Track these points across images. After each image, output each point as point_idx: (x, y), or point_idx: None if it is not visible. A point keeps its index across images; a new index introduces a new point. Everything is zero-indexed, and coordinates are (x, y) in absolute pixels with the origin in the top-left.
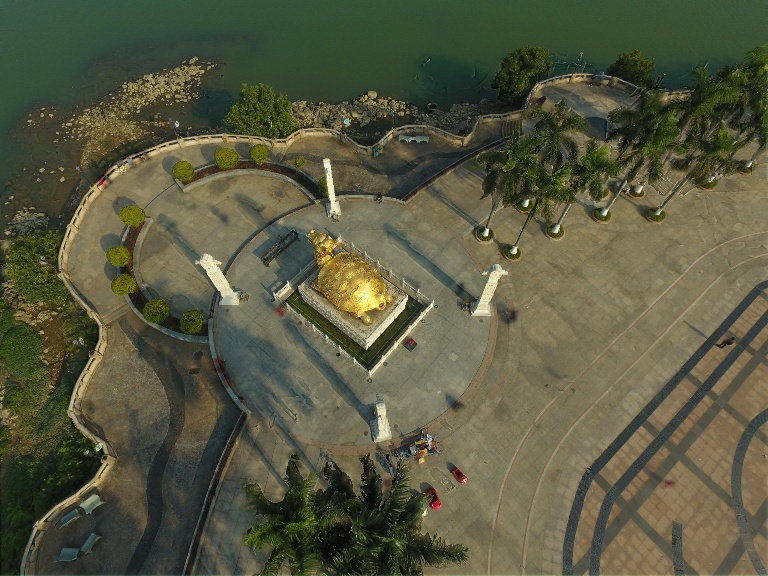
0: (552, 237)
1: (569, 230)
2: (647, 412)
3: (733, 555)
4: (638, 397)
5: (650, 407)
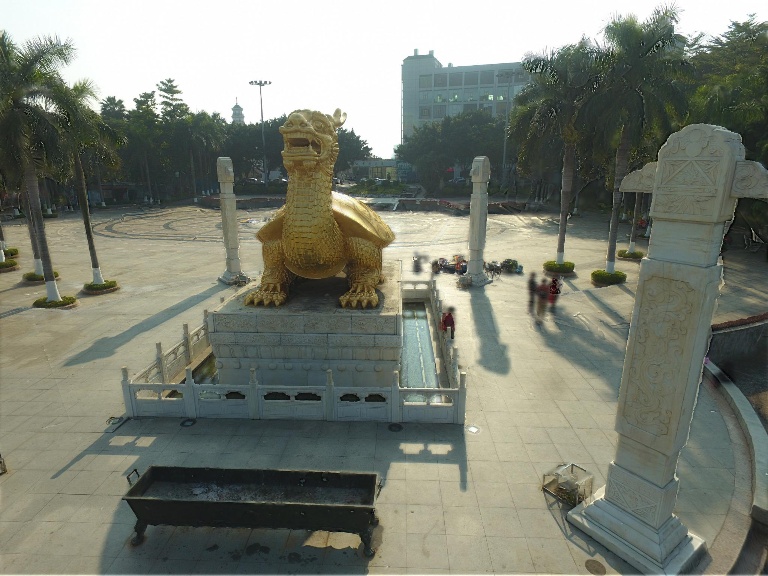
0: (56, 277)
1: None
2: None
3: None
4: None
5: None
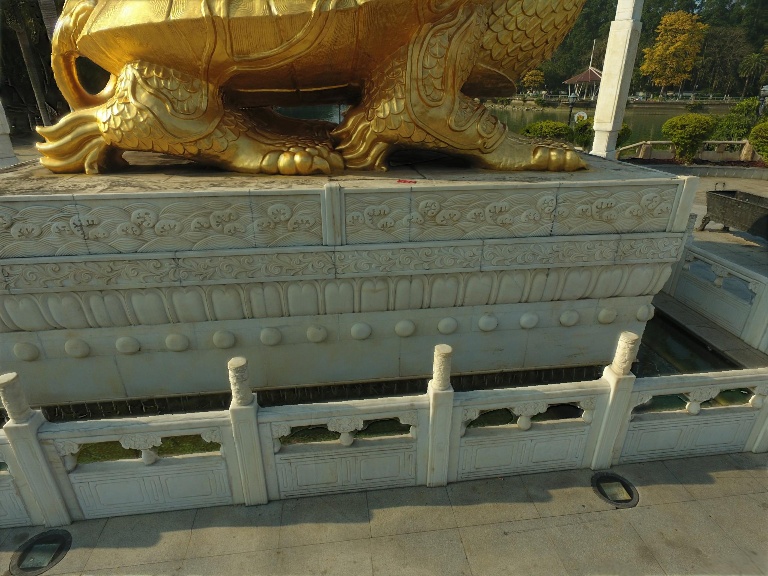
0: None
1: None
2: None
3: None
4: None
5: None
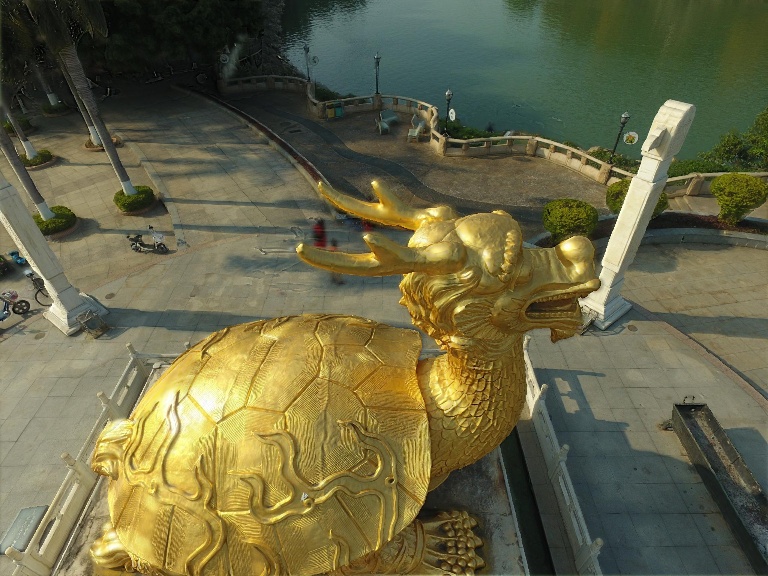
0: None
1: None
2: None
3: None
4: None
5: None
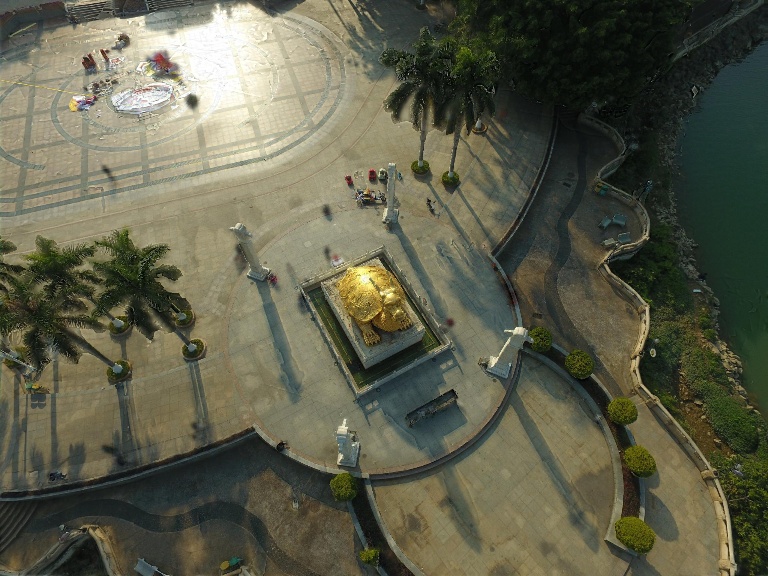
0: None
1: (104, 323)
2: (198, 173)
3: (223, 110)
4: (195, 181)
5: (193, 174)
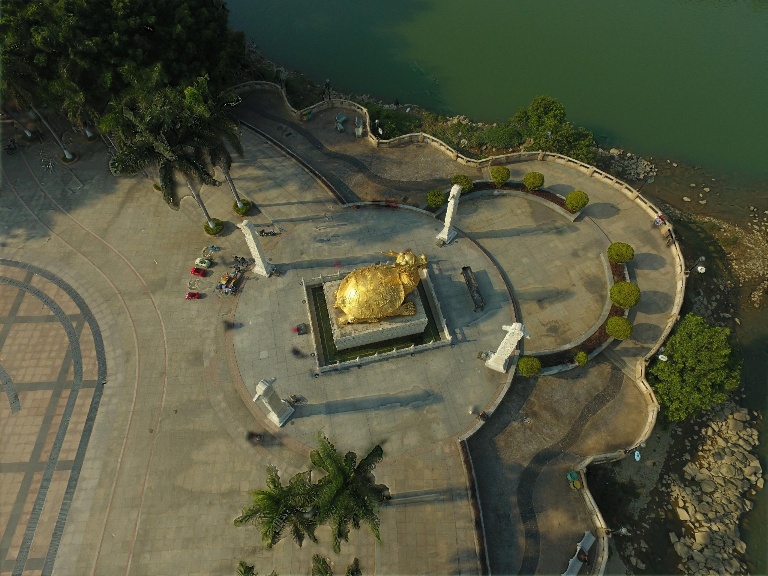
0: None
1: None
2: (74, 478)
3: None
4: (88, 484)
5: (72, 486)
